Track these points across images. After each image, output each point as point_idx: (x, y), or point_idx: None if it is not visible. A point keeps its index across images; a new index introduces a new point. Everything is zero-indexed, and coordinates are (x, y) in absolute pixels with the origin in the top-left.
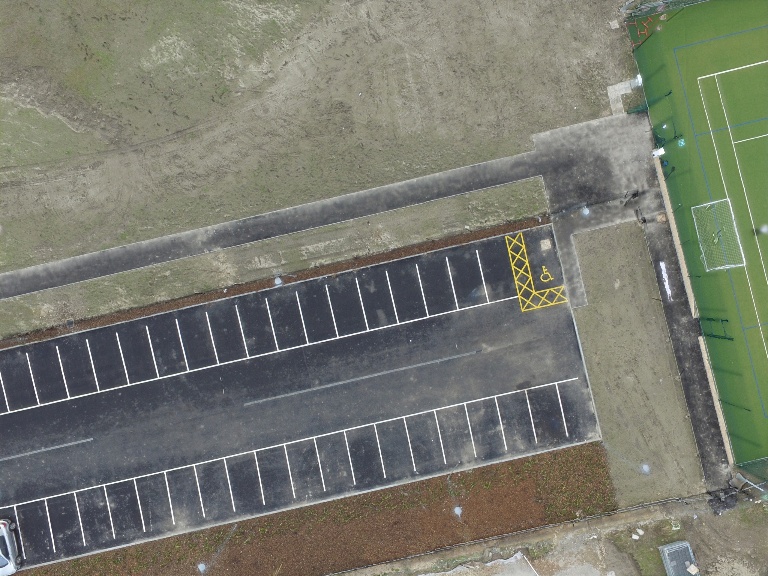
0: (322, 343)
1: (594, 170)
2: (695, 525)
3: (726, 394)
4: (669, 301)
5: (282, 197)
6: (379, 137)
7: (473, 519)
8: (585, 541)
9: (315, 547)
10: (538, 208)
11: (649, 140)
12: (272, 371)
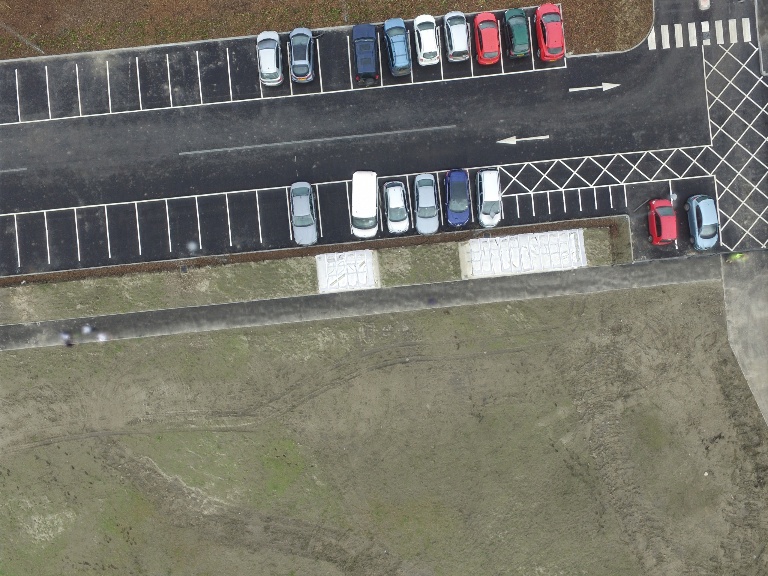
0: None
1: None
2: None
3: None
4: None
5: None
6: None
7: None
8: None
9: None
10: None
11: None
12: None
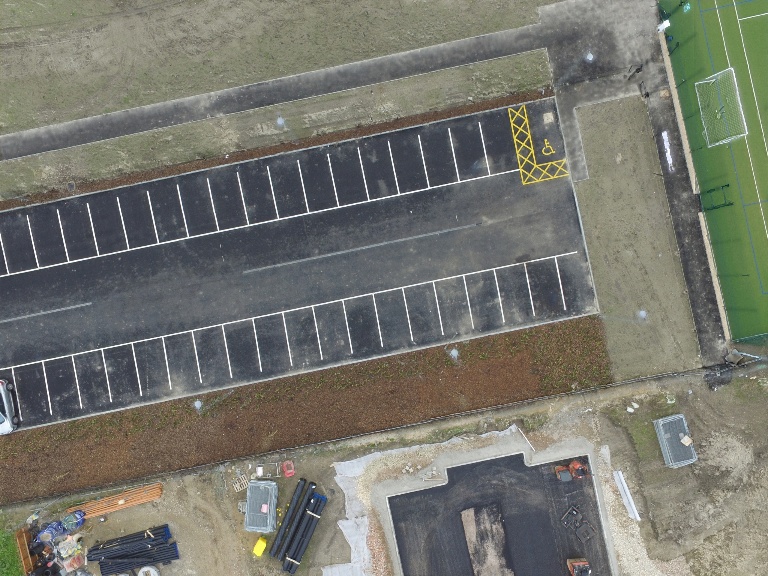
0: (322, 212)
1: (599, 44)
2: (690, 400)
3: (724, 270)
4: (670, 176)
5: (286, 64)
6: (384, 6)
7: (469, 389)
8: (580, 414)
9: (311, 414)
10: (542, 81)
11: (654, 15)
12: (272, 239)
